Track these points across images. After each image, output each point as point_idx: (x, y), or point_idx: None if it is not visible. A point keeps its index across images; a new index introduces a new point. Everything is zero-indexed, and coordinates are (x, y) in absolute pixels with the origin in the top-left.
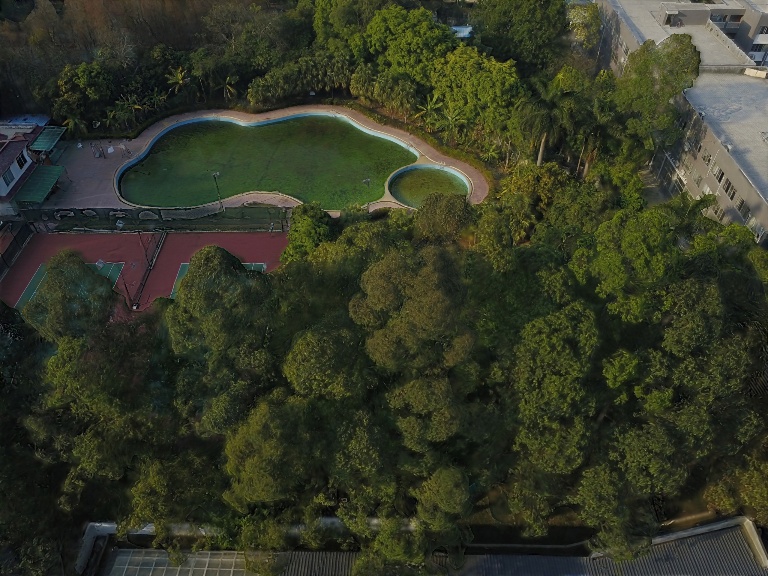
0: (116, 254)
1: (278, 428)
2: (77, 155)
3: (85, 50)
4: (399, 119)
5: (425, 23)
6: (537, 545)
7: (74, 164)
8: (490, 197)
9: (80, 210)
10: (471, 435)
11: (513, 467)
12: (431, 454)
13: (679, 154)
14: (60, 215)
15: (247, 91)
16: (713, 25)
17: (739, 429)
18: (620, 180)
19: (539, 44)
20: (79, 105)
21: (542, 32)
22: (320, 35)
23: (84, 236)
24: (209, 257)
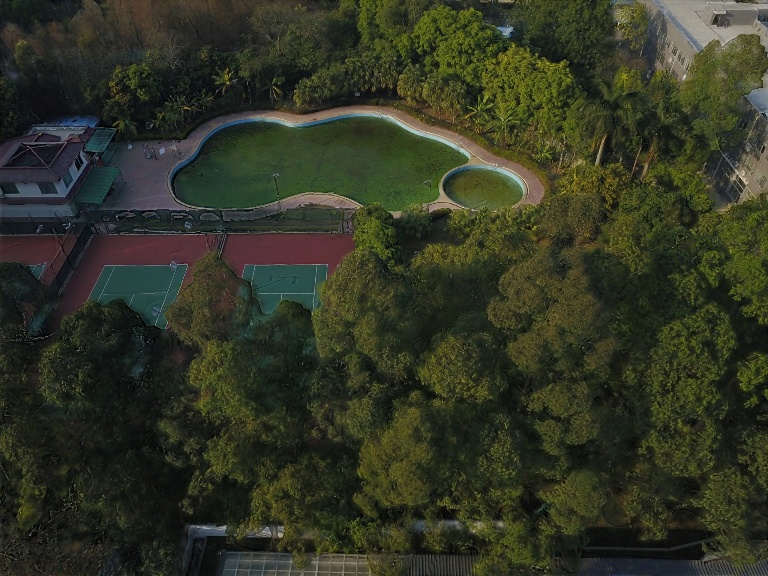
0: (179, 255)
1: (429, 432)
2: (128, 156)
3: (131, 51)
4: (446, 120)
5: (476, 24)
6: (637, 548)
7: (126, 165)
8: (547, 198)
9: (142, 211)
10: (601, 438)
11: (631, 470)
12: (566, 457)
13: (738, 155)
14: (118, 216)
15: (293, 92)
16: (761, 25)
17: None
18: (682, 181)
19: (587, 44)
20: (130, 106)
21: (590, 32)
22: (365, 36)
23: (144, 237)
24: (364, 260)
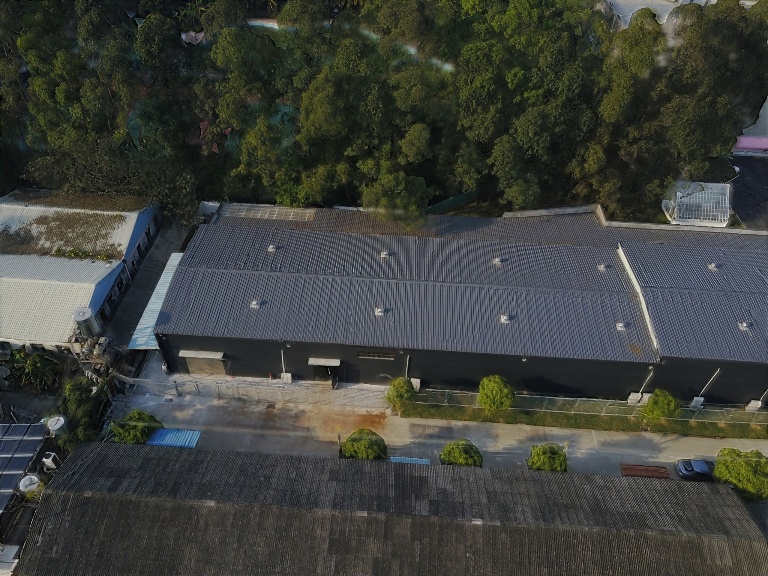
0: None
1: (333, 77)
2: None
3: None
4: None
5: None
6: None
7: None
8: None
9: None
10: (433, 113)
11: (458, 152)
12: (411, 116)
13: None
14: None
15: None
16: None
17: (581, 120)
18: None
19: None
20: (160, 3)
21: None
22: None
23: None
24: None
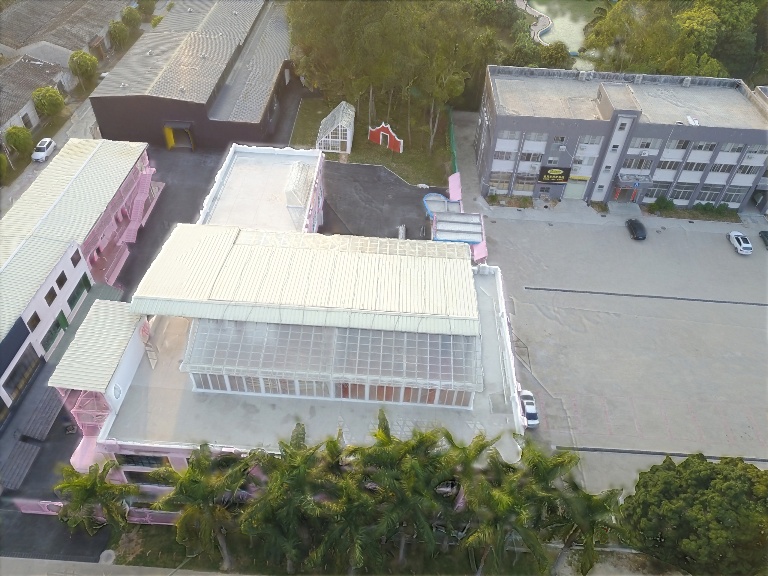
0: None
1: None
2: None
3: None
4: None
5: None
6: None
7: None
8: None
9: None
10: None
11: None
12: None
13: None
14: None
15: None
16: None
17: None
18: None
19: None
20: None
21: None
22: None
23: None
24: None
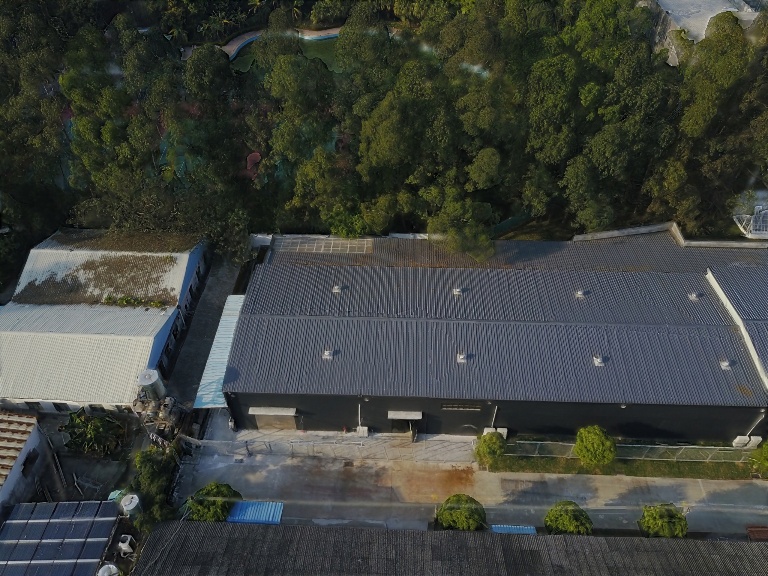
0: None
1: (397, 104)
2: None
3: None
4: None
5: None
6: None
7: None
8: None
9: None
10: (501, 135)
11: (525, 174)
12: (478, 140)
13: (652, 47)
14: None
15: (310, 13)
16: None
17: (660, 135)
18: None
19: None
20: (183, 17)
21: None
22: None
23: None
24: (362, 6)
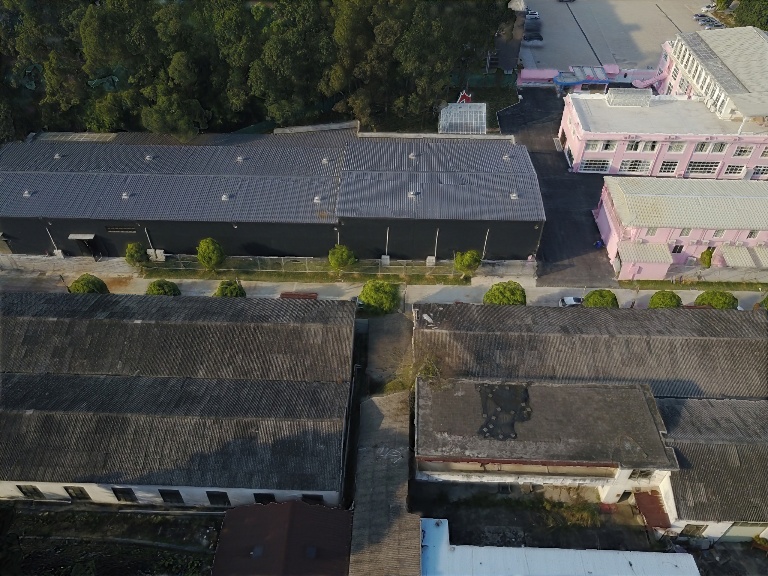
0: None
1: (96, 13)
2: None
3: None
4: None
5: None
6: None
7: None
8: None
9: None
10: (195, 43)
11: (229, 78)
12: (173, 45)
13: None
14: None
15: None
16: None
17: (319, 44)
18: None
19: None
20: None
21: None
22: None
23: None
24: None
